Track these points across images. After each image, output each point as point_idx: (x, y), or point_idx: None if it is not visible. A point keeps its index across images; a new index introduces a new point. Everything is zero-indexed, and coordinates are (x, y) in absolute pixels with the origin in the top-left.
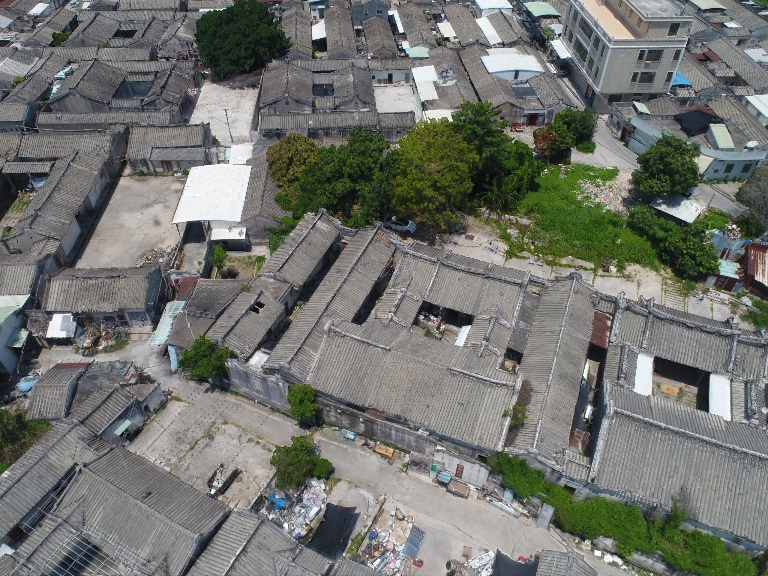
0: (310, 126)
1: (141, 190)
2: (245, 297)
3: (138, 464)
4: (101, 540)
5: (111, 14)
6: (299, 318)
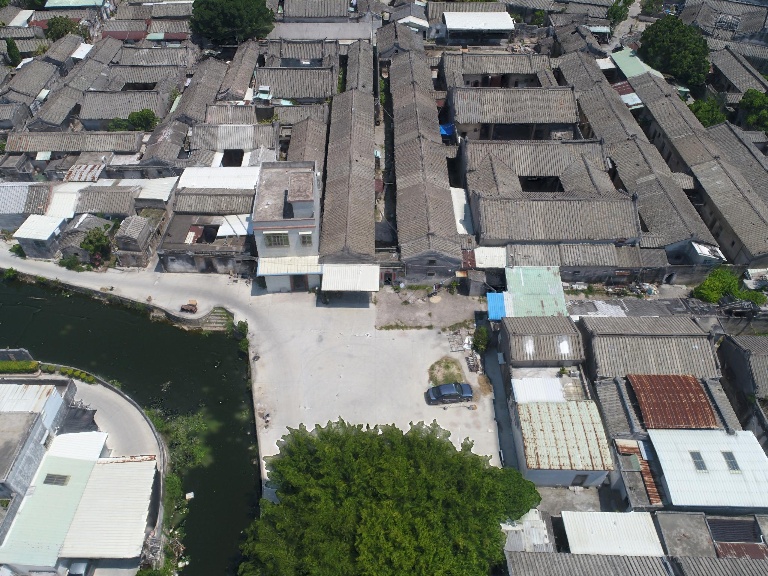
0: (379, 2)
1: None
2: (571, 9)
3: None
4: None
5: (63, 98)
6: (578, 0)
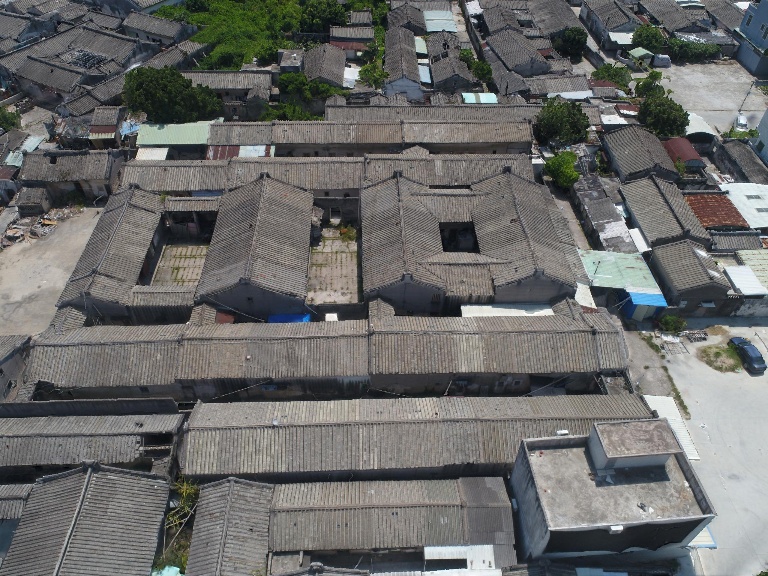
0: None
1: (34, 325)
2: None
3: (58, 85)
4: (77, 63)
5: None
6: None
